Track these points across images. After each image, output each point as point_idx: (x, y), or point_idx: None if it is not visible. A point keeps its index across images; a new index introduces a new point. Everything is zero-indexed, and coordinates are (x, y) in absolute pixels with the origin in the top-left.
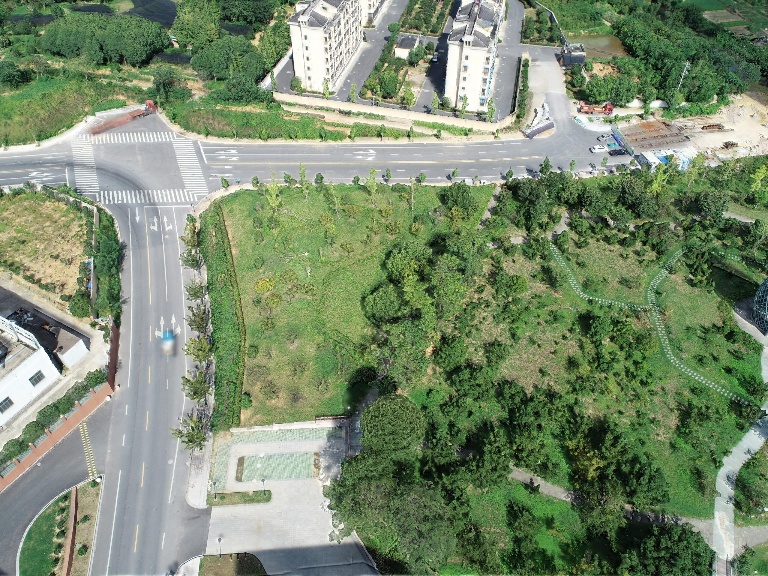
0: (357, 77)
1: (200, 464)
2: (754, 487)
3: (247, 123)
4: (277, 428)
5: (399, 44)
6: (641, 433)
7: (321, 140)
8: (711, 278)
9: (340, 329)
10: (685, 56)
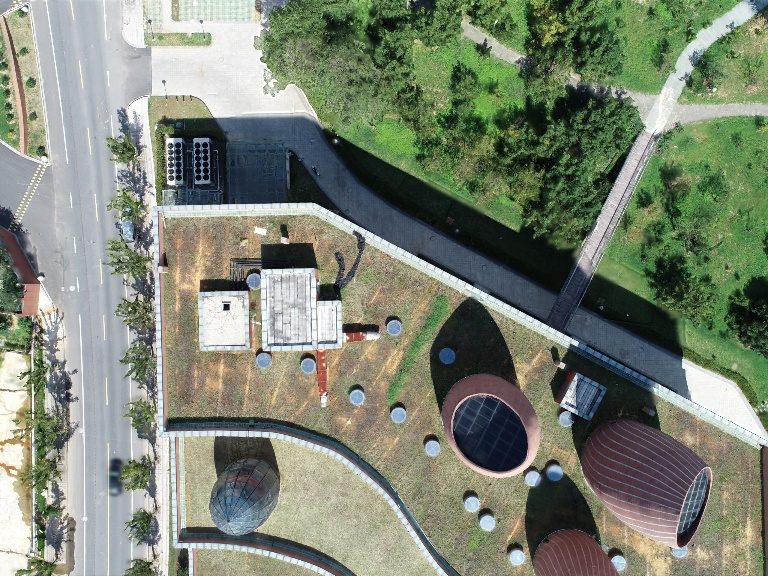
0: None
1: None
2: (714, 66)
3: None
4: None
5: None
6: None
7: None
8: None
9: None
10: None
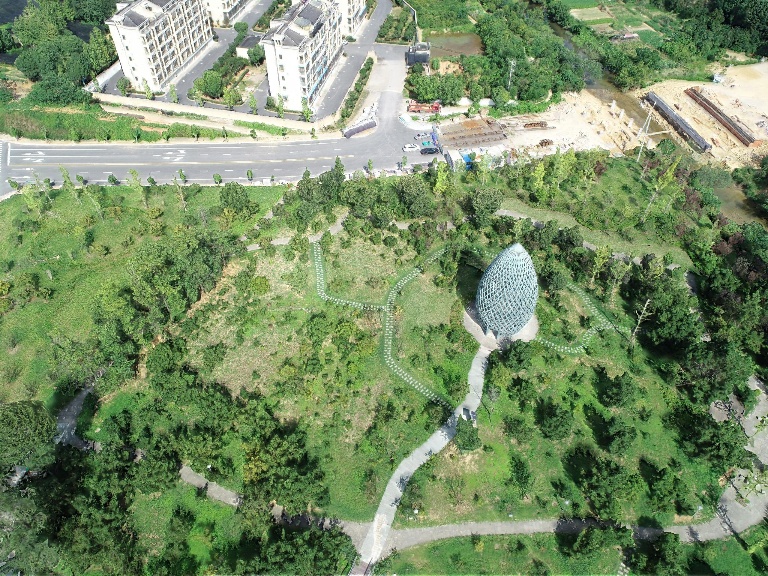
0: (194, 77)
1: None
2: None
3: (59, 124)
4: None
5: (242, 43)
6: (330, 435)
7: (135, 141)
8: (456, 277)
9: (67, 333)
10: (535, 54)
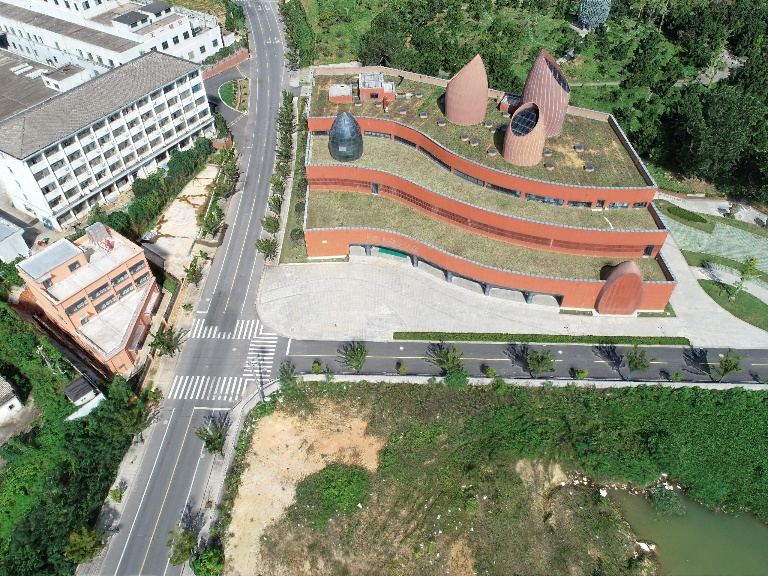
0: None
1: (295, 76)
2: None
3: None
4: (331, 66)
5: None
6: None
7: None
8: (564, 14)
9: None
10: None
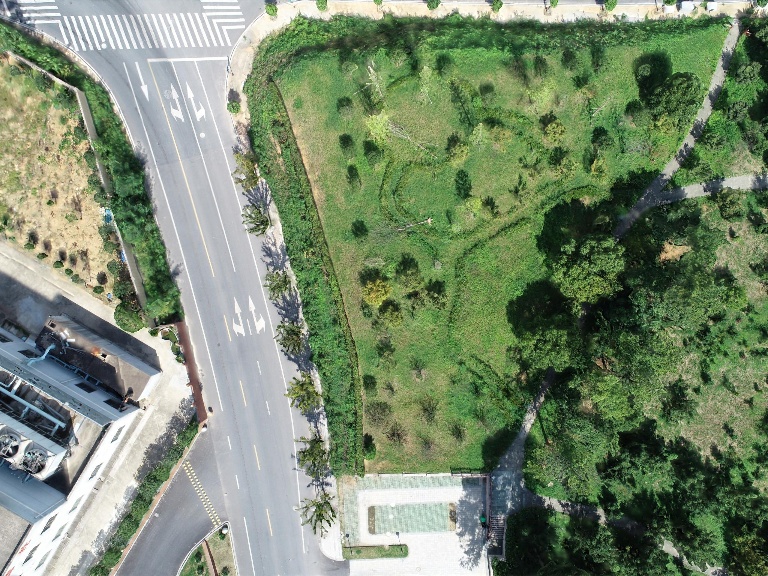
0: None
1: None
2: None
3: None
4: None
5: None
6: None
7: None
8: None
9: (480, 354)
10: None
